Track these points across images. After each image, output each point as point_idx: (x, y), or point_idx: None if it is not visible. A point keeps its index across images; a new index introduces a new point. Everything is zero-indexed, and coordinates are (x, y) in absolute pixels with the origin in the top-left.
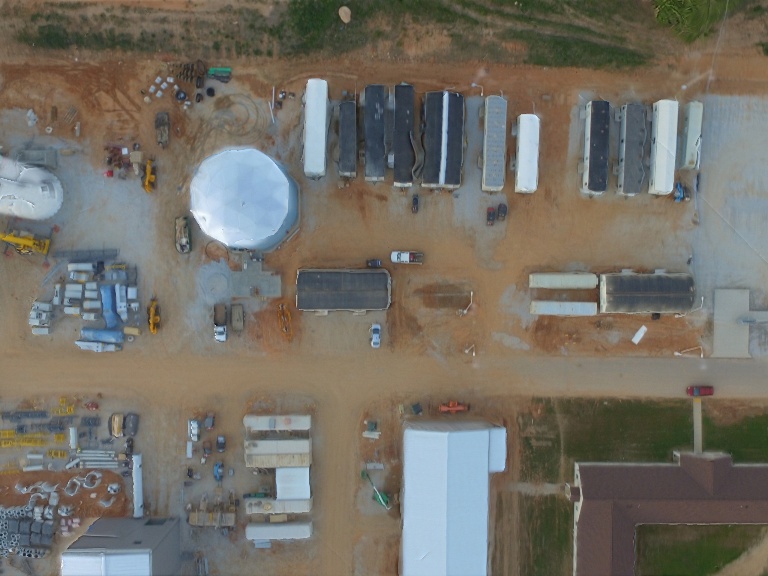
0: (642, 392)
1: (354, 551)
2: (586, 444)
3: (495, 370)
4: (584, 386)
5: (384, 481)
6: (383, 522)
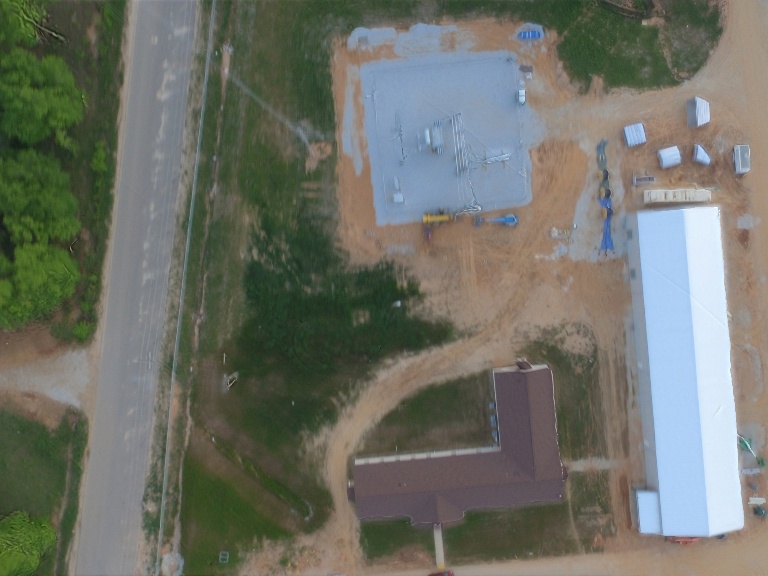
0: (497, 568)
1: (764, 386)
2: (548, 513)
3: (643, 575)
4: (555, 568)
5: (742, 457)
6: (739, 417)
